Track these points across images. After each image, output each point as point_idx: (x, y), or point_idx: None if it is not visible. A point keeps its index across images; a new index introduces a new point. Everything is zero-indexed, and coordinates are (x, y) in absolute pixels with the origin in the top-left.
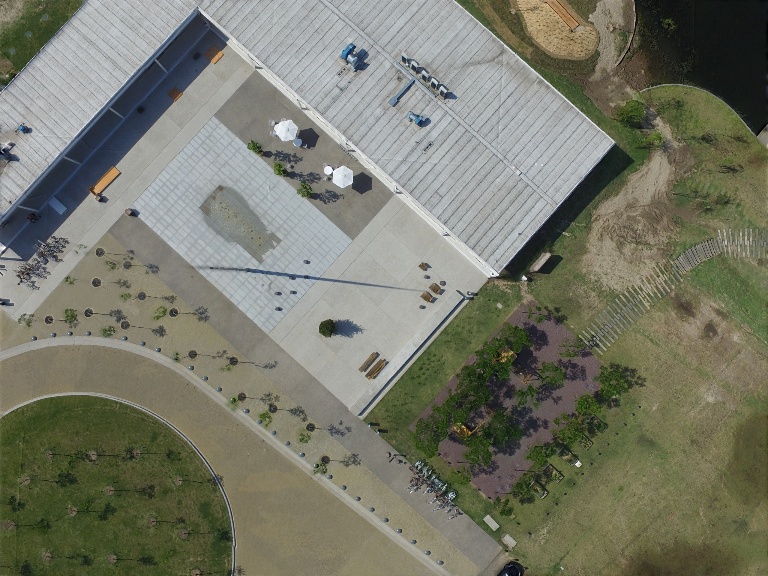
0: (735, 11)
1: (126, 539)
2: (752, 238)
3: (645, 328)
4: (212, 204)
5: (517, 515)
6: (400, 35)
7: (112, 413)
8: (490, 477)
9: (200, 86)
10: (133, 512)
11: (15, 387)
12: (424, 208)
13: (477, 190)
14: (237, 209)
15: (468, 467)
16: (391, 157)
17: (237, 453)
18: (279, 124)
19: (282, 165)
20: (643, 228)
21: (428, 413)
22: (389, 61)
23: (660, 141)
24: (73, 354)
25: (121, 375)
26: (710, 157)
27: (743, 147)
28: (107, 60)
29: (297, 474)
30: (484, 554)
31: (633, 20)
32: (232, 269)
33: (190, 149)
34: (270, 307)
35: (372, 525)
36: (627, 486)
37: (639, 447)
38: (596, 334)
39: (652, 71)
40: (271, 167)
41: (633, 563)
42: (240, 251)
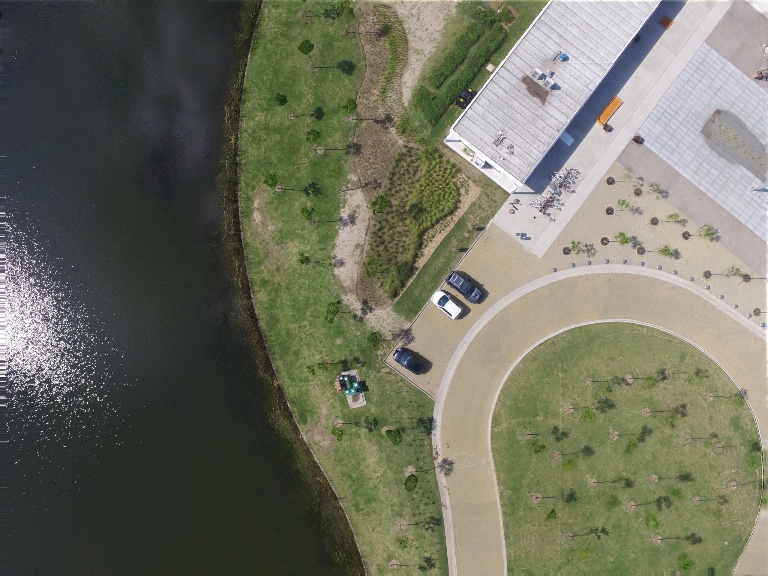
0: None
1: (663, 459)
2: None
3: None
4: (712, 128)
5: None
6: None
7: (641, 337)
8: None
9: (688, 13)
10: (668, 432)
11: (540, 320)
12: None
13: None
14: (736, 131)
15: None
16: None
17: (757, 366)
18: None
19: None
20: None
21: None
22: None
23: None
24: (594, 283)
25: (642, 300)
26: None
27: None
28: None
29: None
30: None
31: None
32: None
33: (686, 75)
34: None
35: None
36: None
37: None
38: None
39: None
40: (763, 89)
41: None
42: (743, 171)
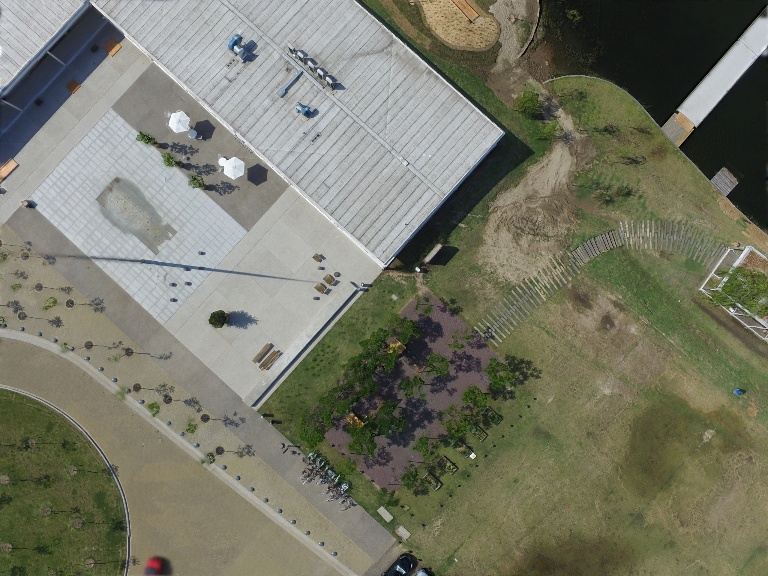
0: (641, 2)
1: (21, 528)
2: (654, 230)
3: (541, 320)
4: (109, 196)
5: (411, 507)
6: (289, 26)
7: (8, 403)
8: (384, 468)
9: (98, 78)
10: (28, 501)
11: None
12: (311, 199)
13: (364, 181)
14: (133, 201)
15: (362, 458)
16: (278, 148)
17: (132, 443)
18: (171, 116)
19: (178, 157)
20: (543, 220)
21: None
22: (278, 52)
23: (562, 132)
24: None
25: (18, 365)
26: (612, 148)
27: (646, 138)
28: None
29: (191, 465)
30: (378, 545)
31: (537, 11)
32: (113, 259)
33: (87, 141)
34: (165, 298)
35: (266, 516)
36: (522, 478)
37: (534, 439)
38: (492, 326)
39: (556, 62)
40: None
41: (528, 555)
42: (136, 242)
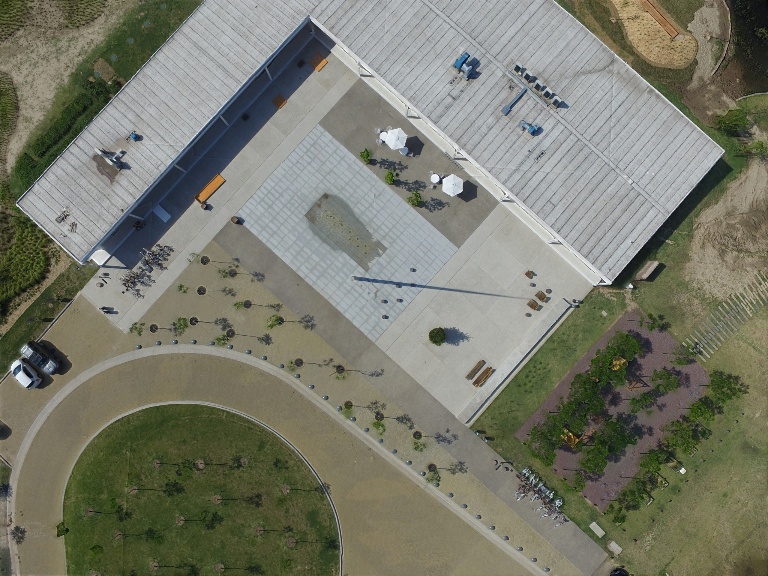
0: None
1: (233, 548)
2: None
3: (748, 335)
4: (317, 212)
5: None
6: (511, 44)
7: (219, 422)
8: (596, 484)
9: (304, 94)
10: (240, 521)
11: (120, 396)
12: (537, 217)
13: (589, 199)
14: (342, 217)
15: (574, 474)
16: (504, 166)
17: (344, 461)
18: (388, 132)
19: None
20: (742, 236)
21: (534, 421)
22: (501, 70)
23: (757, 149)
24: (178, 362)
25: (227, 383)
26: None
27: None
28: (218, 68)
29: (404, 482)
30: (590, 561)
31: (728, 29)
32: None
33: (295, 157)
34: (376, 315)
35: (479, 533)
36: (731, 492)
37: (742, 454)
38: (699, 341)
39: (747, 80)
40: (376, 175)
41: (737, 569)
42: (346, 259)
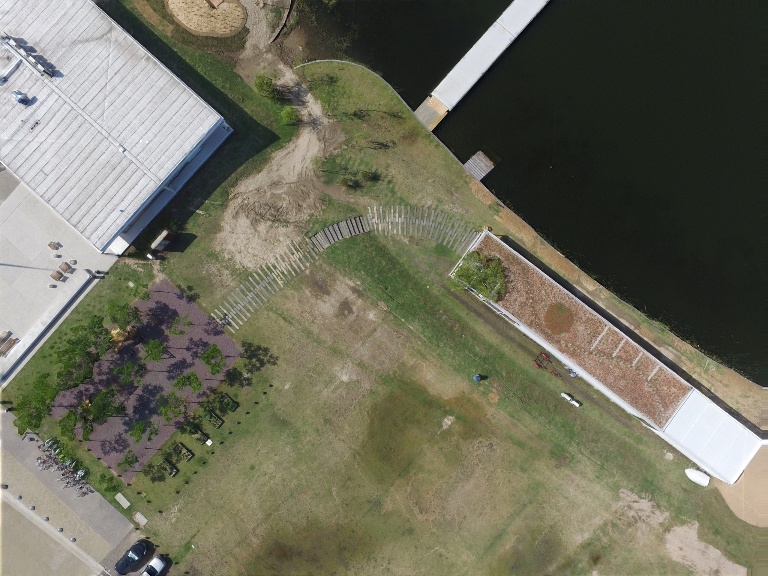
0: None
1: None
2: (404, 215)
3: (278, 306)
4: None
5: (148, 493)
6: (10, 14)
7: None
8: (120, 455)
9: None
10: None
11: None
12: (28, 186)
13: (82, 168)
14: None
15: (99, 445)
16: None
17: None
18: None
19: None
20: (287, 206)
21: None
22: None
23: (310, 118)
24: None
25: None
26: (362, 133)
27: (397, 123)
28: None
29: None
30: (116, 532)
31: None
32: None
33: None
34: None
35: (6, 502)
36: (258, 465)
37: (271, 426)
38: (228, 312)
39: (310, 47)
40: None
41: (264, 542)
42: None
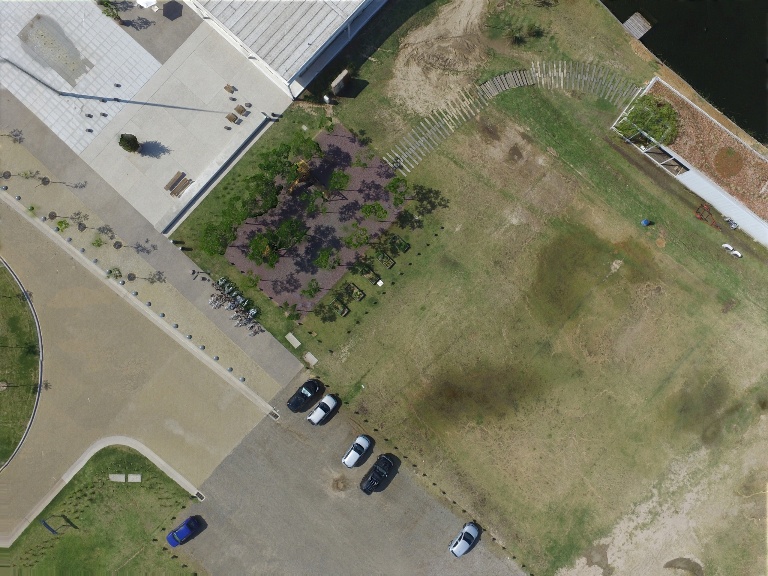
0: None
1: None
2: (566, 70)
3: (449, 150)
4: (29, 32)
5: (319, 333)
6: None
7: None
8: (292, 295)
9: None
10: None
11: None
12: (217, 20)
13: (270, 3)
14: (53, 36)
15: (270, 285)
16: None
17: (46, 270)
18: None
19: None
20: (454, 58)
21: None
22: None
23: None
24: None
25: None
26: None
27: None
28: None
29: (104, 291)
30: (285, 371)
31: None
32: (20, 69)
33: None
34: (81, 129)
35: (176, 341)
36: (429, 306)
37: (441, 267)
38: (400, 156)
39: None
40: None
41: (434, 383)
42: (54, 76)
